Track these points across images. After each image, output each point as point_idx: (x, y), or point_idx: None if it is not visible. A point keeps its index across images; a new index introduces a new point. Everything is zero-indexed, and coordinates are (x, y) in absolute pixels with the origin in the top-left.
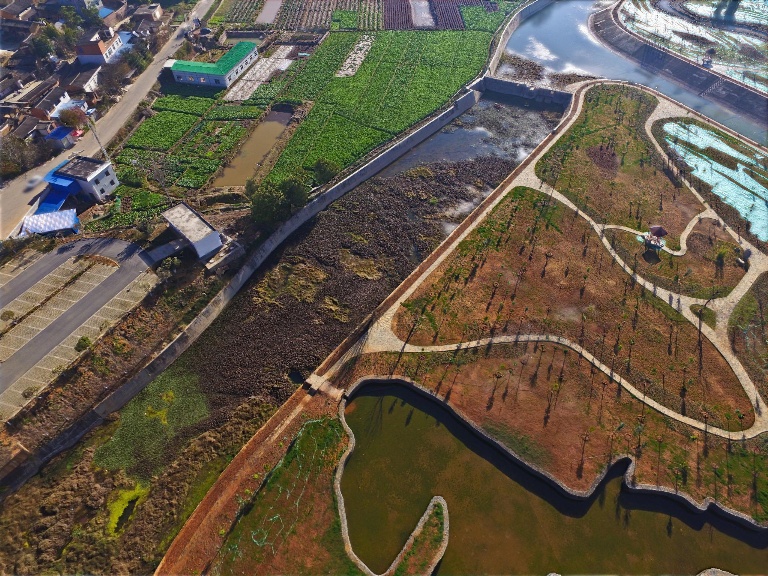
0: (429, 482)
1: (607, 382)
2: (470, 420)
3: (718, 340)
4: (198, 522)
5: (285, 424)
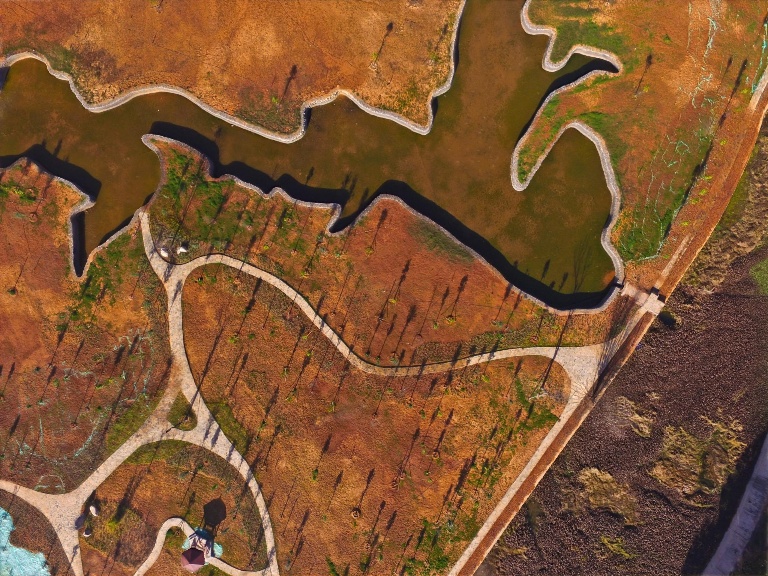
0: (527, 206)
1: (330, 315)
2: (486, 265)
3: (182, 376)
4: (739, 160)
5: (677, 255)
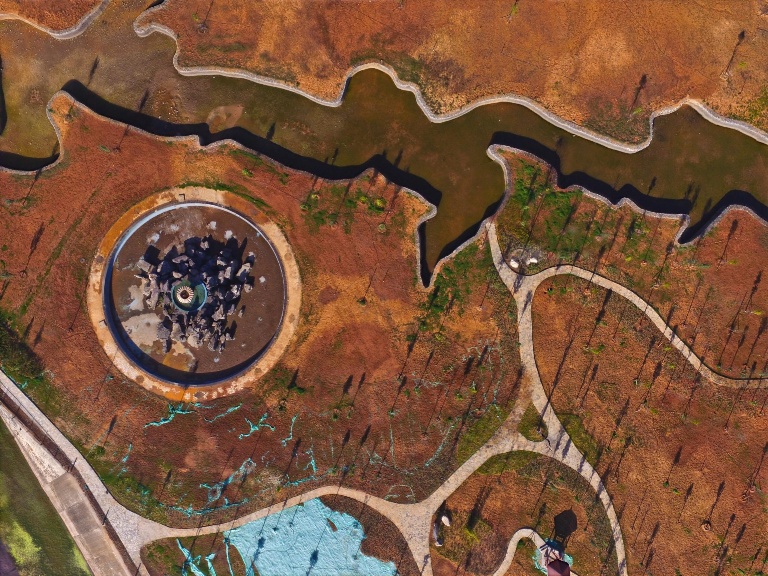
0: None
1: (681, 327)
2: None
3: (533, 387)
4: None
5: None
